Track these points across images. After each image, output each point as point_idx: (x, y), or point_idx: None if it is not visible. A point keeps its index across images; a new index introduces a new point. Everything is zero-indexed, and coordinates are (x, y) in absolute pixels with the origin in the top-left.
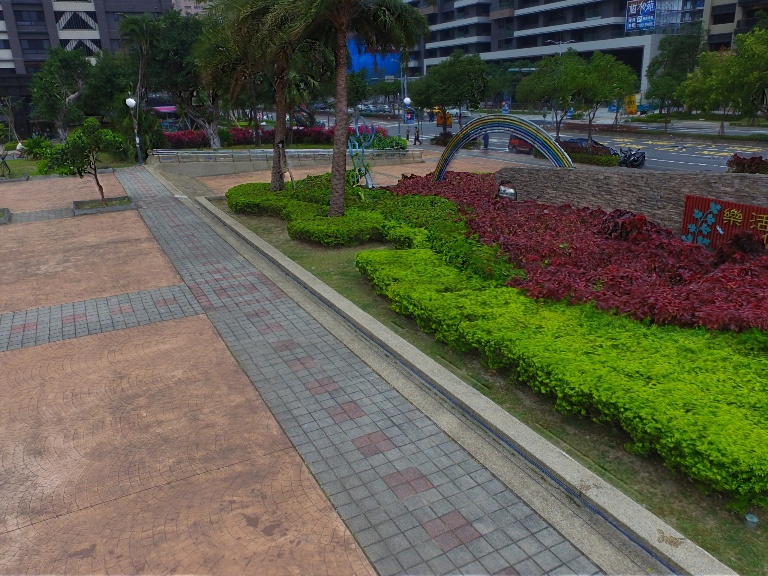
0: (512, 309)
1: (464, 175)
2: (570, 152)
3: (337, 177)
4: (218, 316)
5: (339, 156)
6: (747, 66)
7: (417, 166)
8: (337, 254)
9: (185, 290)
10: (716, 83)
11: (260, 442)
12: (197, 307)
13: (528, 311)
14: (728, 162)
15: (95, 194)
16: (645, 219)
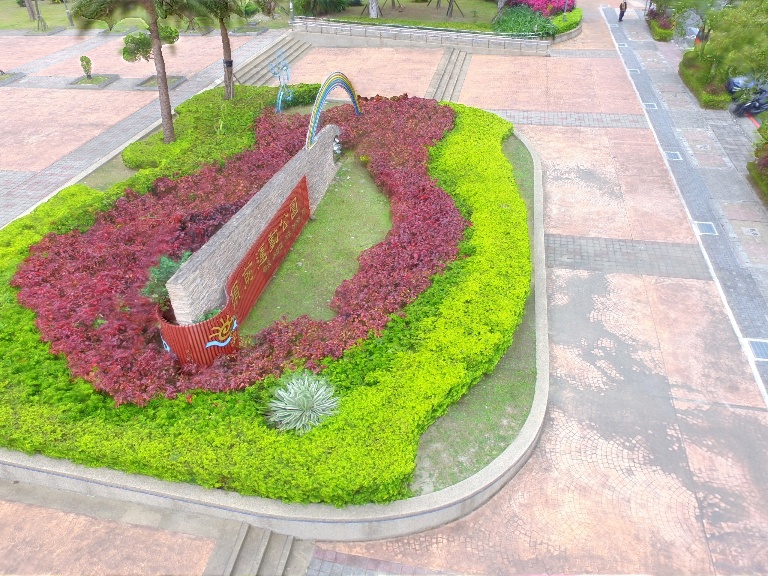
0: (2, 250)
1: (418, 105)
2: (695, 77)
3: (162, 116)
4: None
5: (161, 102)
6: (739, 38)
7: (524, 62)
8: (121, 175)
9: (28, 177)
10: (706, 52)
11: None
12: (7, 191)
13: (9, 254)
14: (755, 150)
15: (191, 65)
16: (181, 218)
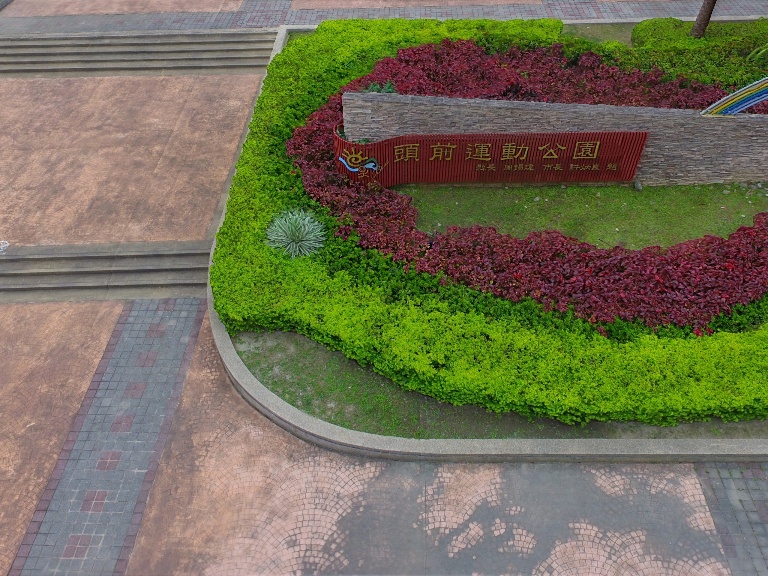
0: (442, 31)
1: None
2: None
3: None
4: (536, 5)
5: None
6: None
7: None
8: (619, 39)
9: (583, 1)
10: None
11: (422, 3)
12: (553, 2)
13: None
14: None
15: None
16: (508, 84)
